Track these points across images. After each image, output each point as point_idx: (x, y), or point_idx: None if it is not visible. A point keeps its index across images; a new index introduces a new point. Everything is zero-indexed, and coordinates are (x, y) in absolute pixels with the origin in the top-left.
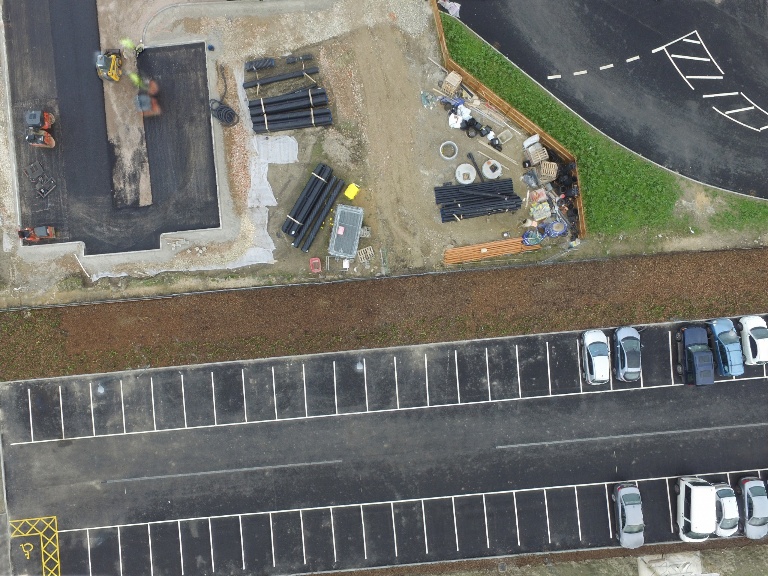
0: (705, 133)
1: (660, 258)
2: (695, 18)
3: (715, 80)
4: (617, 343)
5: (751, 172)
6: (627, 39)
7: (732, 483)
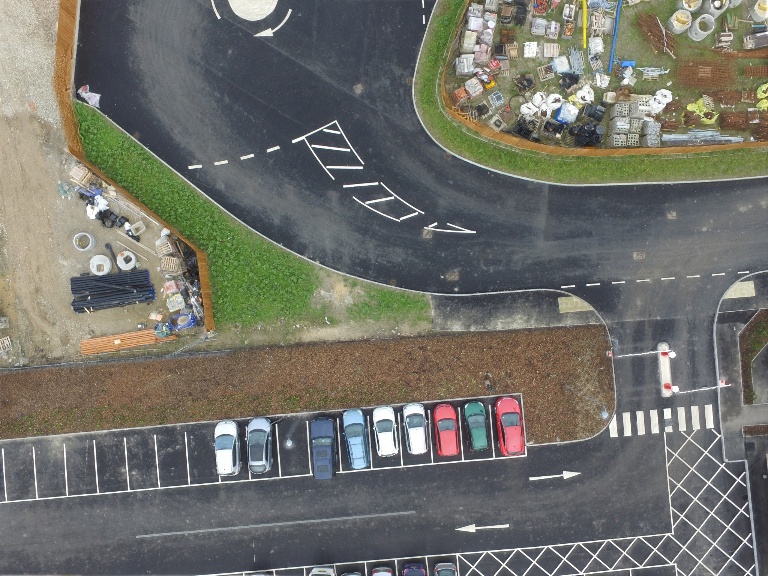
0: (345, 223)
1: (296, 348)
2: (335, 108)
3: (355, 170)
4: (247, 435)
5: (391, 262)
6: (267, 129)
7: (369, 572)
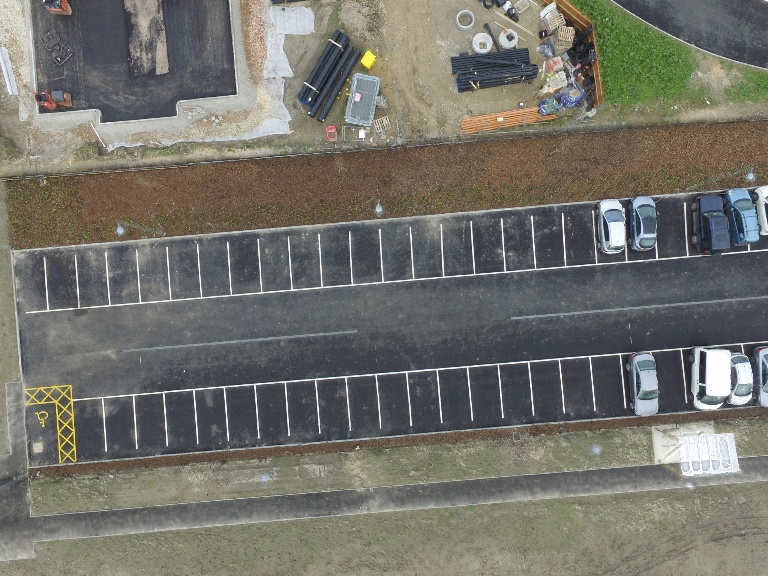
0: (721, 6)
1: (676, 129)
2: None
3: None
4: (633, 211)
5: (767, 45)
6: None
7: (746, 354)
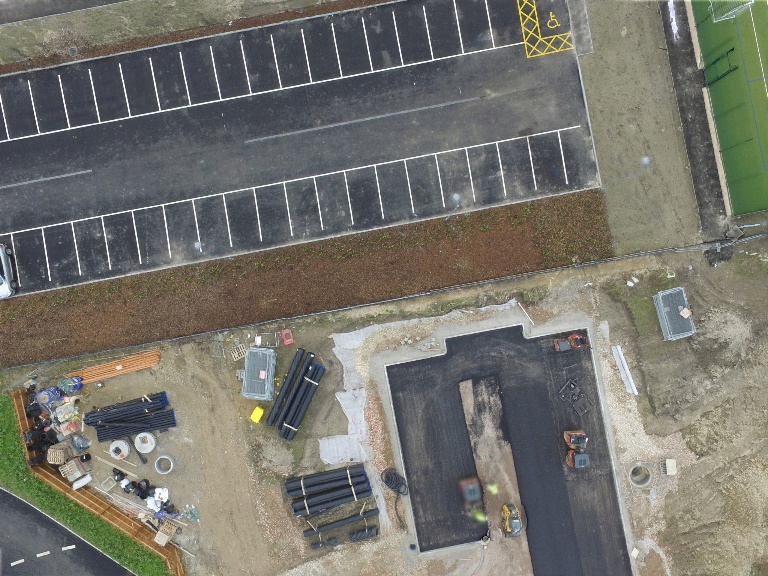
0: None
1: None
2: None
3: None
4: None
5: None
6: None
7: None
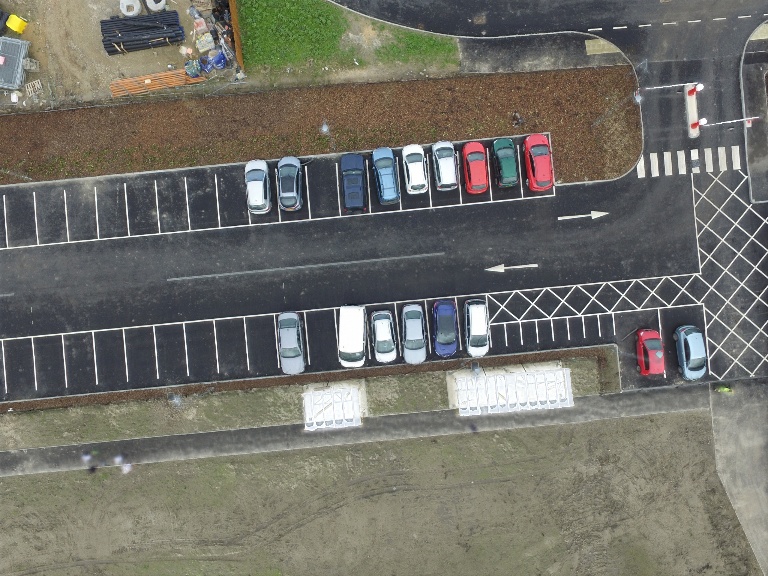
0: None
1: (325, 90)
2: None
3: None
4: None
5: (419, 6)
6: None
7: (399, 312)
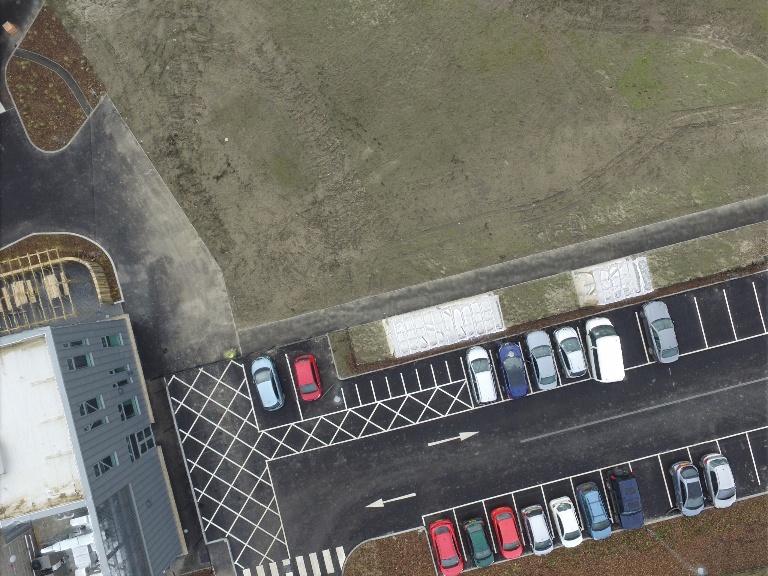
0: None
1: None
2: None
3: None
4: None
5: None
6: None
7: (557, 377)
